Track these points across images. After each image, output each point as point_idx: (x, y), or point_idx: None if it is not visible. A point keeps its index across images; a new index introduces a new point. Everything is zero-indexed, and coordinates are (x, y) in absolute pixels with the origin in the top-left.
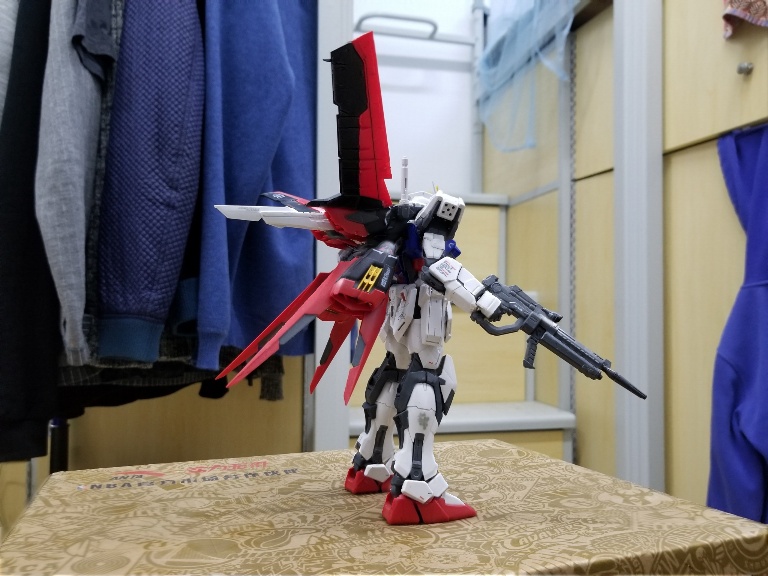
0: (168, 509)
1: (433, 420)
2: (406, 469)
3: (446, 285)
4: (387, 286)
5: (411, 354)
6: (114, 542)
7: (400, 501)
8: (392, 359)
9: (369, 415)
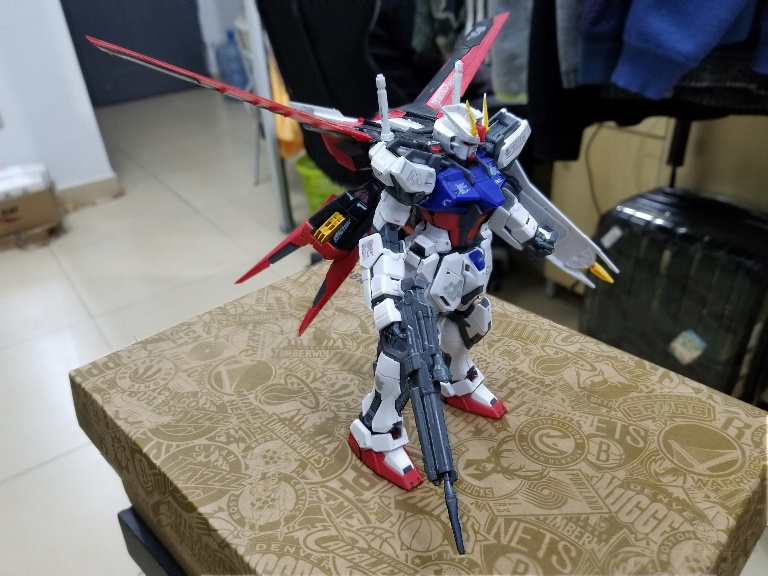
0: (323, 322)
1: (395, 386)
2: (364, 411)
3: None
4: (339, 242)
5: None
6: (245, 336)
7: None
8: None
9: None
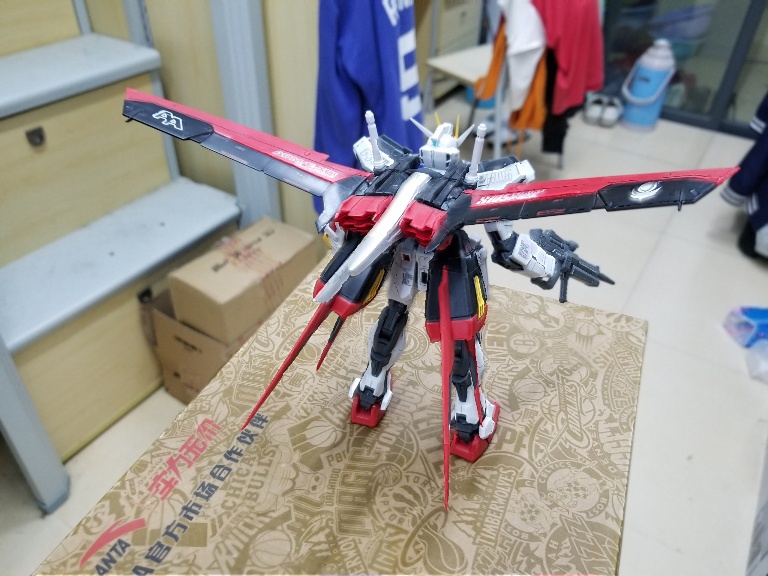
0: None
1: None
2: (476, 418)
3: (527, 268)
4: None
5: None
6: None
7: (479, 444)
8: (403, 309)
9: (380, 363)
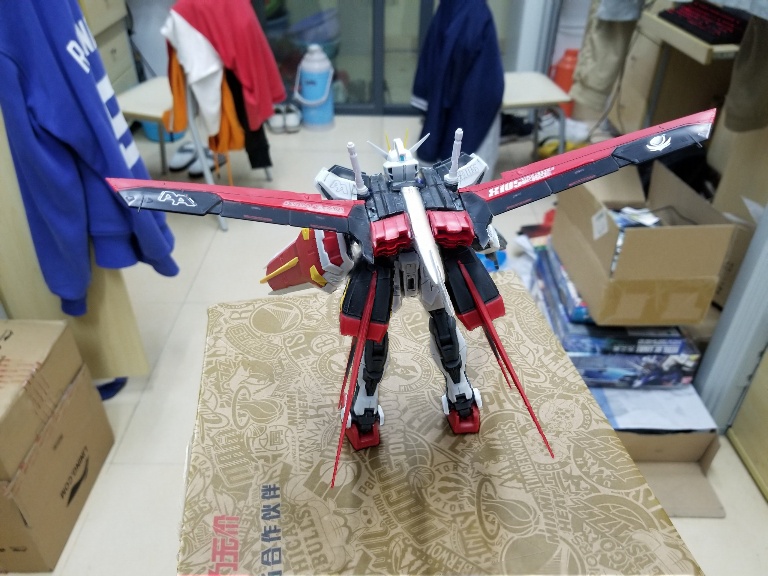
0: None
1: None
2: None
3: None
4: None
5: (435, 310)
6: None
7: None
8: None
9: (375, 380)
